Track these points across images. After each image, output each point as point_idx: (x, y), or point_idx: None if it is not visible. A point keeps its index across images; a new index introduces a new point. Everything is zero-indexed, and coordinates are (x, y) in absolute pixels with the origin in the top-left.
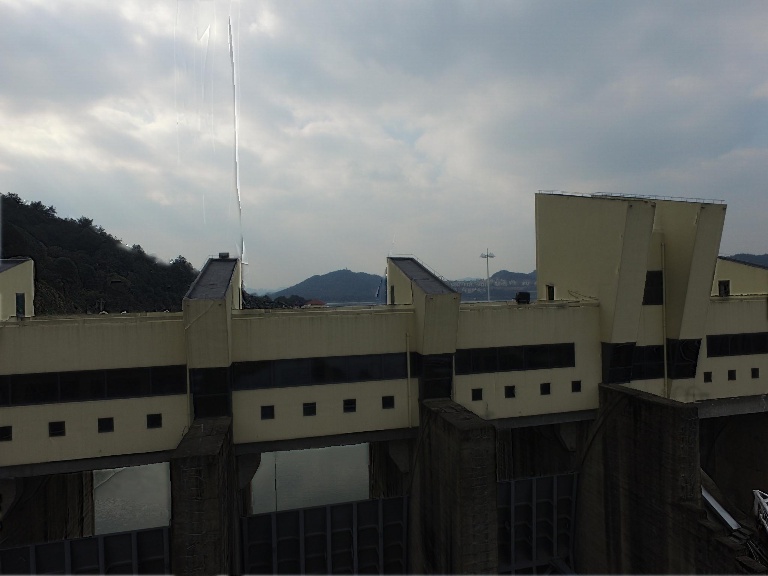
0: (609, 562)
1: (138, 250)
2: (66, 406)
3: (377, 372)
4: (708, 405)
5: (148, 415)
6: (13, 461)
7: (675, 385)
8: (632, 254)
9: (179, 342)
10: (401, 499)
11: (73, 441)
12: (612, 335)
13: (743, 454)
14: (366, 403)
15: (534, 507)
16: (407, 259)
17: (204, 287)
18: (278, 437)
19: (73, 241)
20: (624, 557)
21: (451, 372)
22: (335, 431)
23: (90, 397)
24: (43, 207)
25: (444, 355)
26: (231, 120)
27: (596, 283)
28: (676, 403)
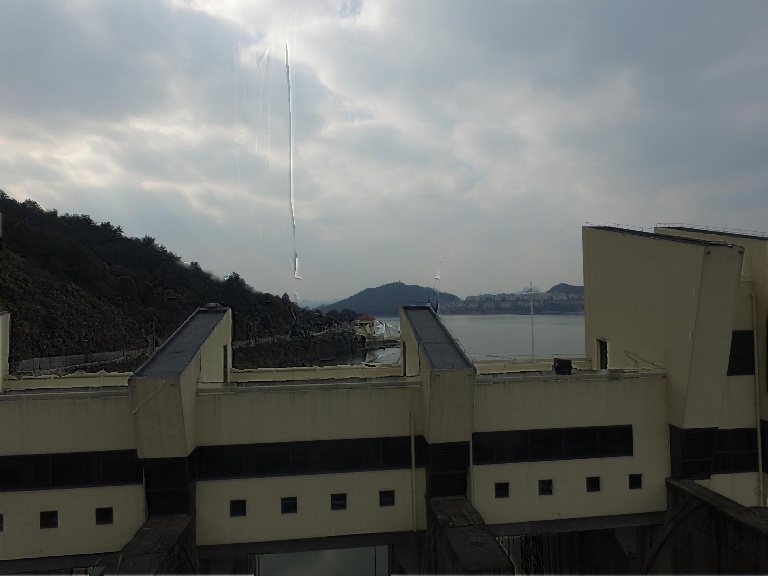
0: None
1: (195, 267)
2: (5, 496)
3: (374, 459)
4: None
5: (97, 509)
6: None
7: None
8: (711, 314)
9: None
10: None
11: (12, 538)
12: (684, 418)
13: None
14: (359, 499)
15: None
16: (424, 308)
17: (166, 356)
18: (250, 539)
19: (136, 259)
20: None
21: (466, 464)
22: (320, 533)
23: (34, 485)
24: (112, 227)
25: (456, 444)
26: (287, 139)
27: (661, 347)
28: None
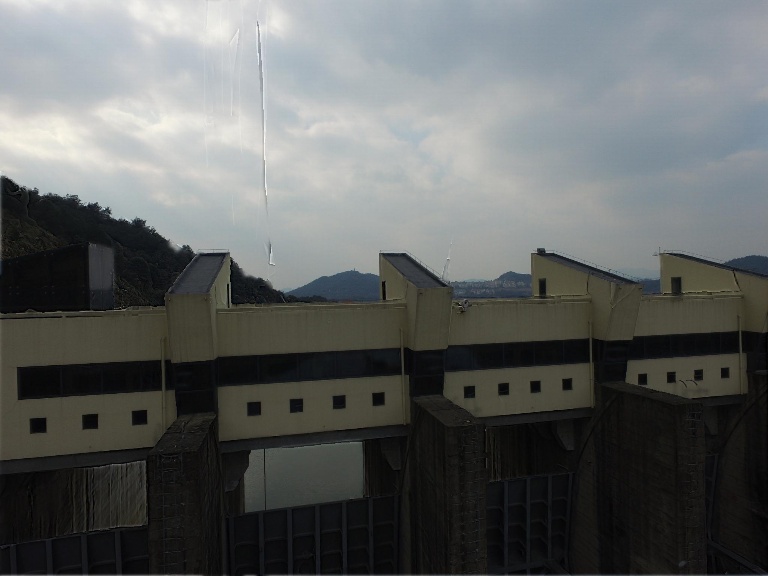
0: None
1: (188, 250)
2: (509, 371)
3: (714, 348)
4: None
5: (563, 379)
6: (475, 414)
7: None
8: None
9: (583, 320)
10: (713, 457)
11: (514, 399)
12: None
13: None
14: (710, 373)
15: None
16: (678, 254)
17: (598, 275)
18: None
19: (132, 241)
20: None
21: None
22: (688, 396)
23: (522, 364)
24: (99, 208)
25: None
26: None
27: None
28: None
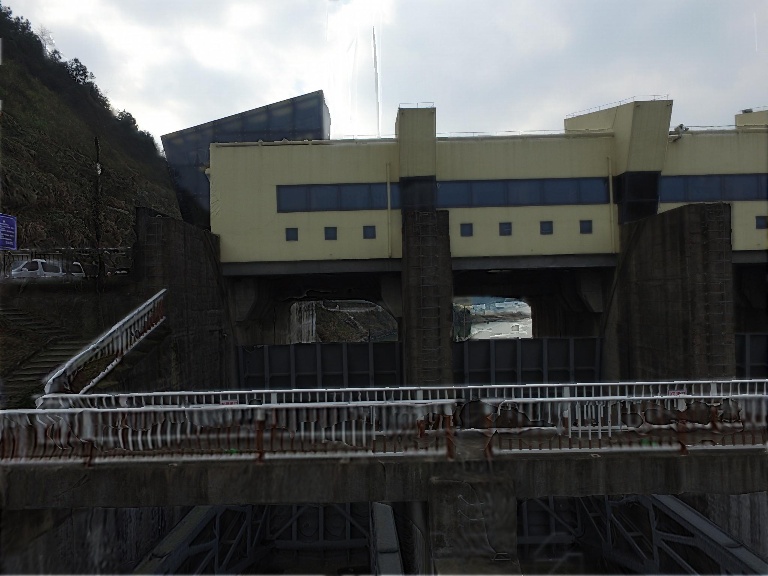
0: None
1: None
2: None
3: None
4: None
5: None
6: None
7: None
8: None
9: None
10: None
11: (736, 234)
12: None
13: None
14: None
15: None
16: None
17: None
18: None
19: None
20: None
21: None
22: None
23: (744, 199)
24: None
25: None
26: (375, 124)
27: None
28: None
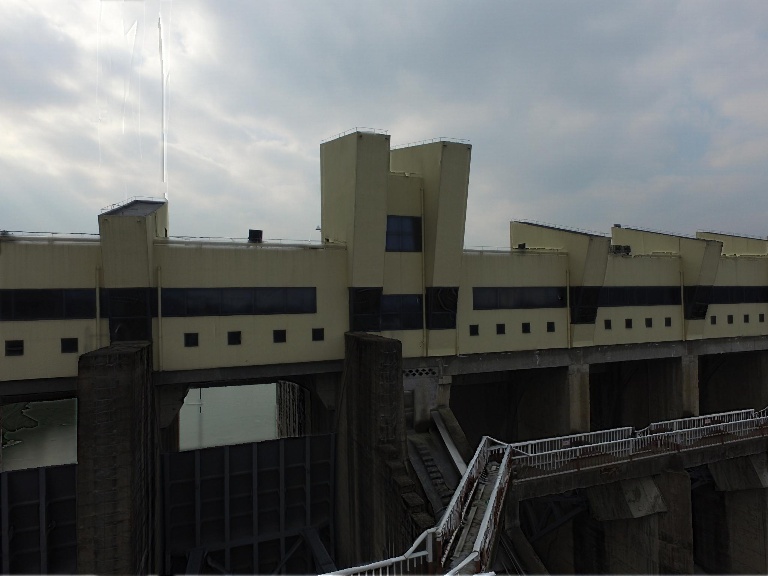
0: (350, 525)
1: None
2: None
3: (59, 311)
4: (476, 360)
5: None
6: None
7: (433, 336)
8: (368, 190)
9: None
10: None
11: None
12: (353, 278)
13: (536, 417)
14: (38, 345)
15: (282, 471)
16: (160, 203)
17: None
18: None
19: None
20: (356, 517)
21: (147, 310)
22: None
23: None
24: None
25: (135, 290)
26: (159, 120)
27: (345, 225)
28: (384, 339)
